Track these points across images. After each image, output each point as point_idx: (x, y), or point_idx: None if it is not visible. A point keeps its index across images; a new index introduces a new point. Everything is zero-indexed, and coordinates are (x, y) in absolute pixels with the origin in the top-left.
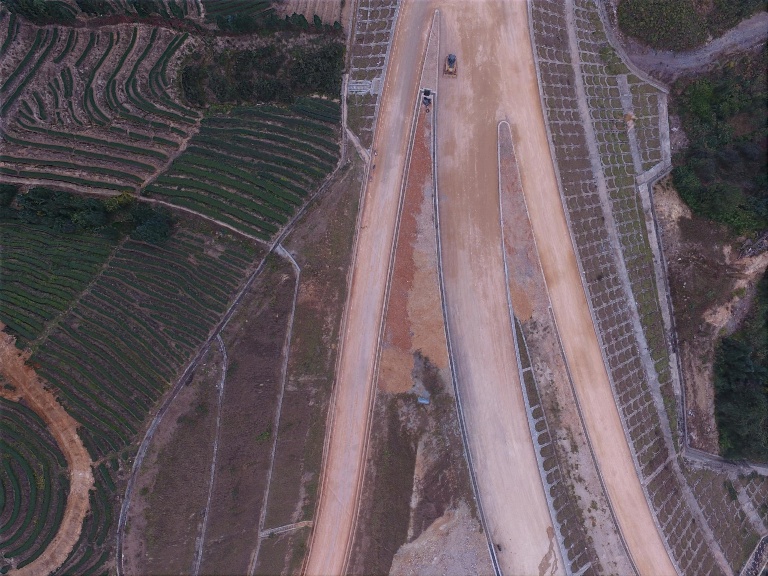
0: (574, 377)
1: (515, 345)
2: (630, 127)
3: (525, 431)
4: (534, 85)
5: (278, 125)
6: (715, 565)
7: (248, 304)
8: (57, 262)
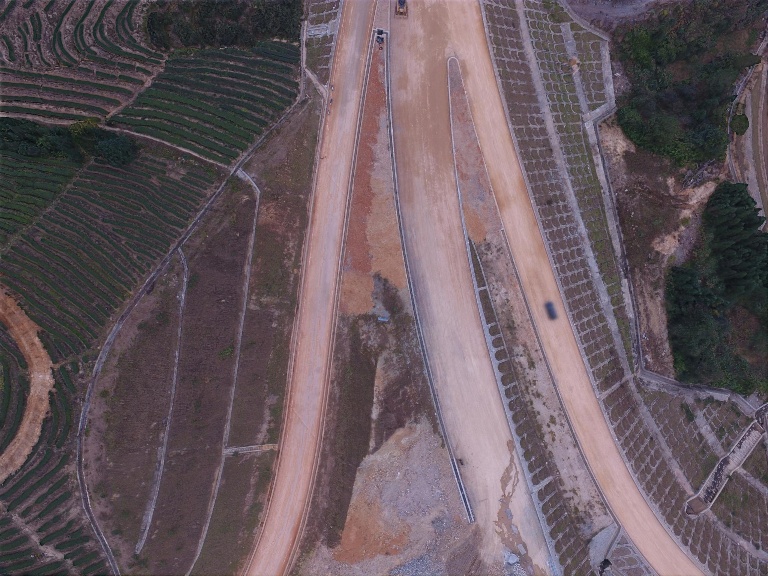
0: (528, 296)
1: (470, 265)
2: (575, 71)
3: (483, 347)
4: (480, 24)
5: (240, 65)
6: (675, 482)
7: (209, 221)
8: (22, 183)
